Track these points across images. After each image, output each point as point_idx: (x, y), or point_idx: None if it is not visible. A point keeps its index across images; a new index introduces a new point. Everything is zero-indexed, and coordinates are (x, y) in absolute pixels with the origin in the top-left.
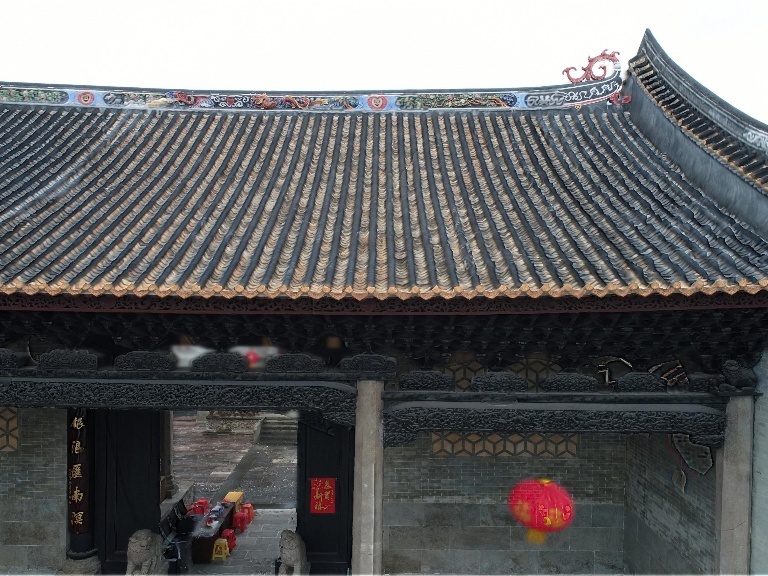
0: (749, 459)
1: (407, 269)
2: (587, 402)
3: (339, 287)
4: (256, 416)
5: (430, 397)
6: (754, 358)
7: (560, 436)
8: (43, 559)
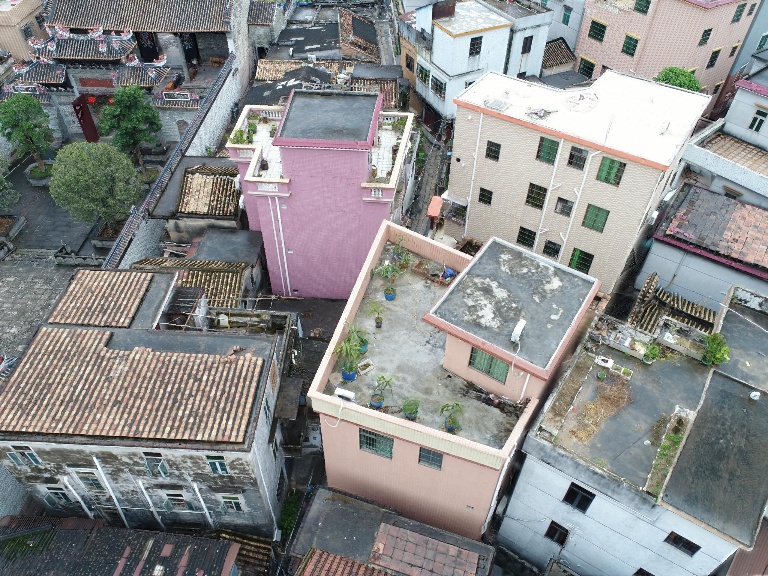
0: None
1: None
2: None
3: None
4: None
5: None
6: None
7: None
8: None
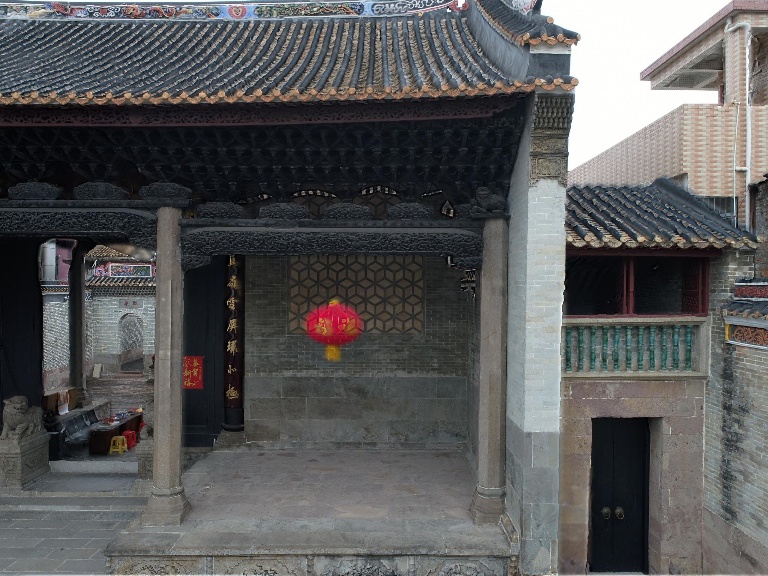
0: (501, 275)
1: None
2: (360, 227)
3: None
4: None
5: (221, 223)
6: (504, 185)
7: (407, 314)
8: None
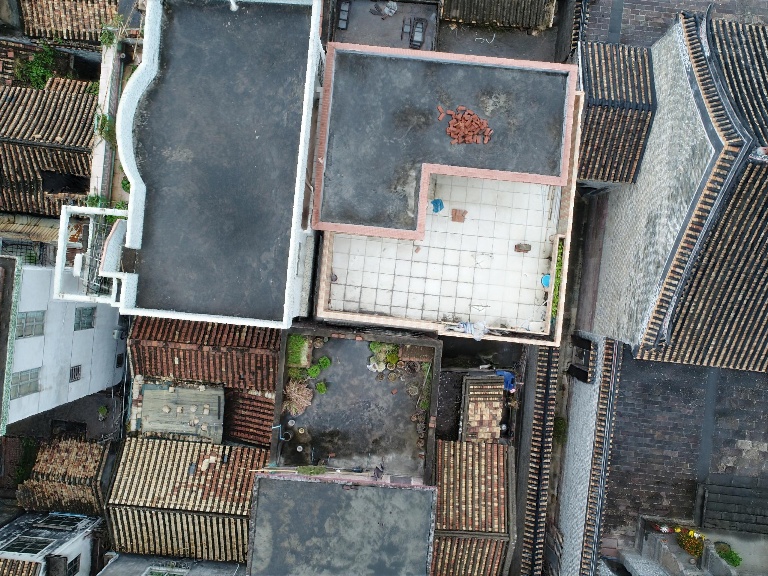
0: None
1: None
2: None
3: None
4: None
5: None
6: None
7: None
8: None
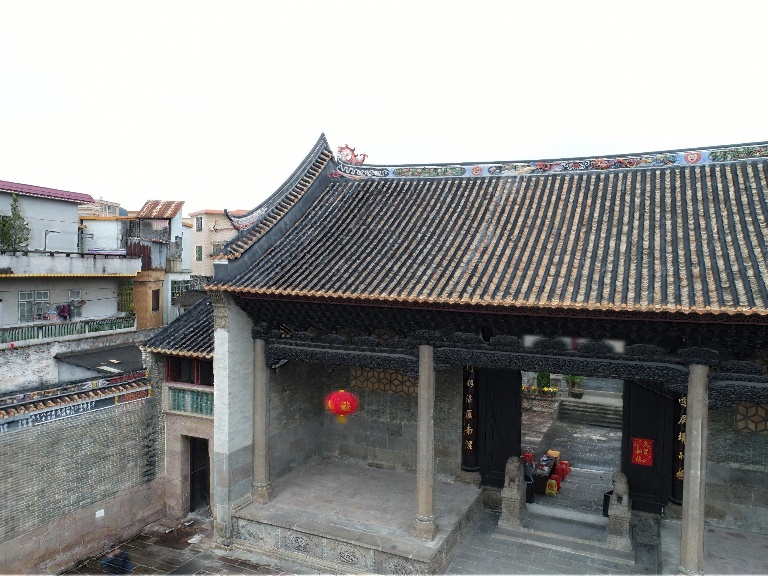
0: None
1: (731, 294)
2: None
3: (686, 306)
4: (554, 398)
5: (744, 378)
6: None
7: None
8: (447, 468)
